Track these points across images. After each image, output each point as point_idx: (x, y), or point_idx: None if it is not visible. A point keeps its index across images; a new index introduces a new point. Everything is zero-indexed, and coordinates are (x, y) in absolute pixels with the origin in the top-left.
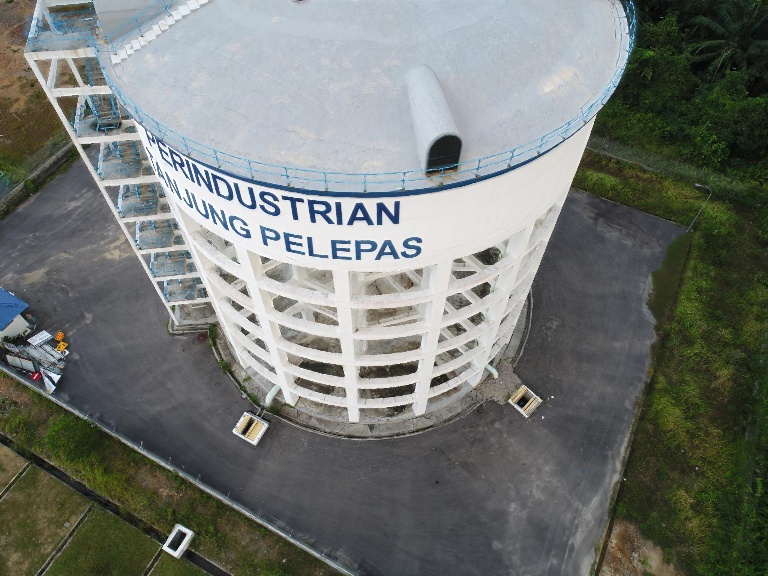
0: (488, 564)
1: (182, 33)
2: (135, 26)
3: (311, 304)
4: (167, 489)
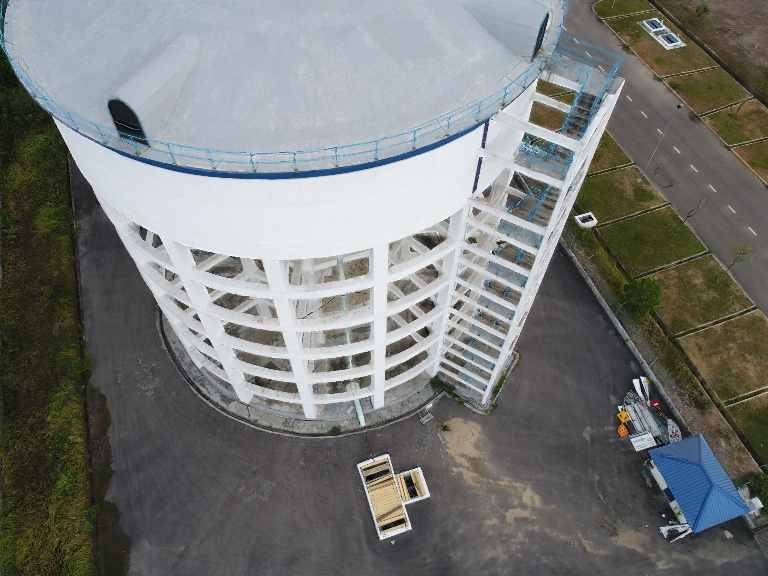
0: None
1: None
2: None
3: None
4: (579, 253)
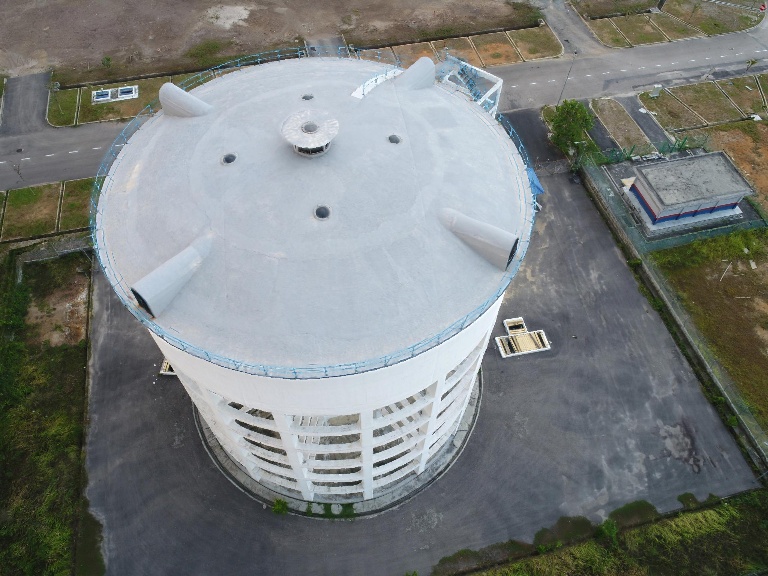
0: None
1: None
2: None
3: None
4: None
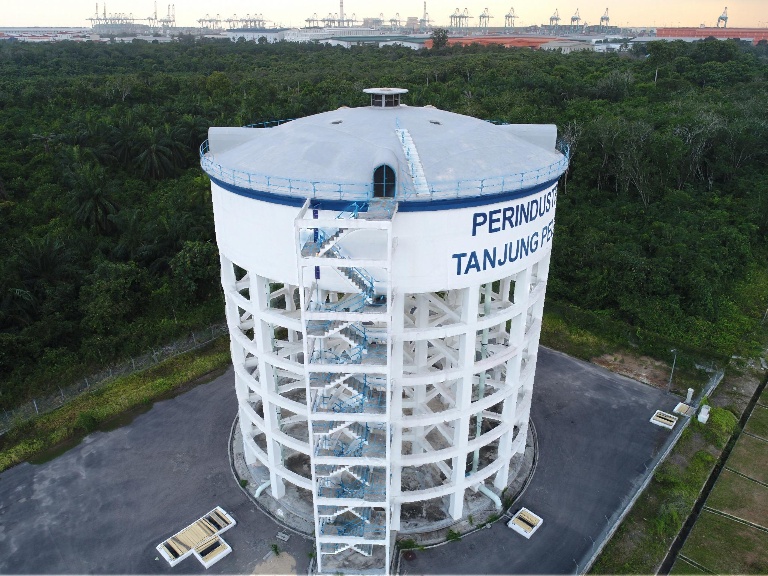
0: (628, 412)
1: (434, 158)
2: (398, 178)
3: (424, 429)
4: None
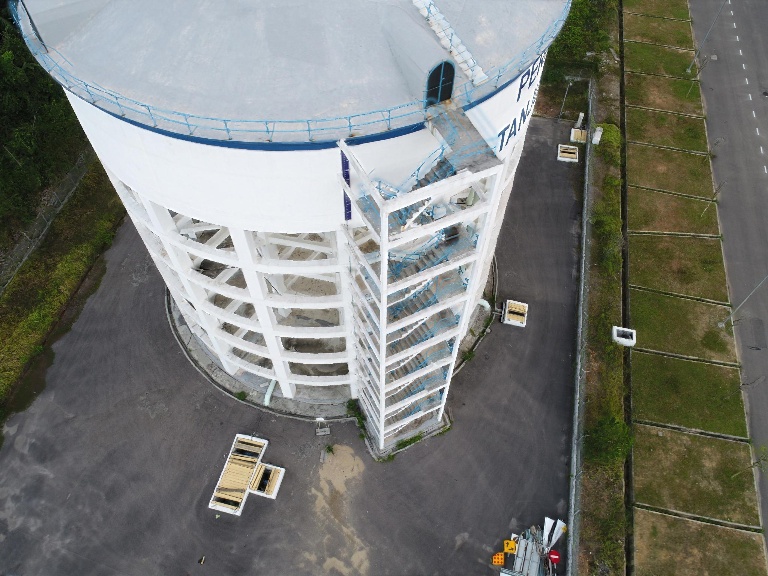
0: (537, 157)
1: (455, 3)
2: None
3: None
4: (592, 364)
